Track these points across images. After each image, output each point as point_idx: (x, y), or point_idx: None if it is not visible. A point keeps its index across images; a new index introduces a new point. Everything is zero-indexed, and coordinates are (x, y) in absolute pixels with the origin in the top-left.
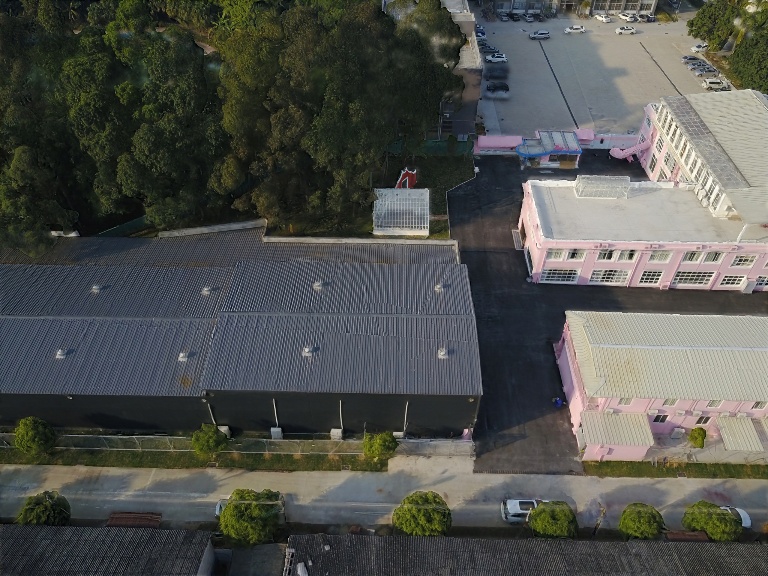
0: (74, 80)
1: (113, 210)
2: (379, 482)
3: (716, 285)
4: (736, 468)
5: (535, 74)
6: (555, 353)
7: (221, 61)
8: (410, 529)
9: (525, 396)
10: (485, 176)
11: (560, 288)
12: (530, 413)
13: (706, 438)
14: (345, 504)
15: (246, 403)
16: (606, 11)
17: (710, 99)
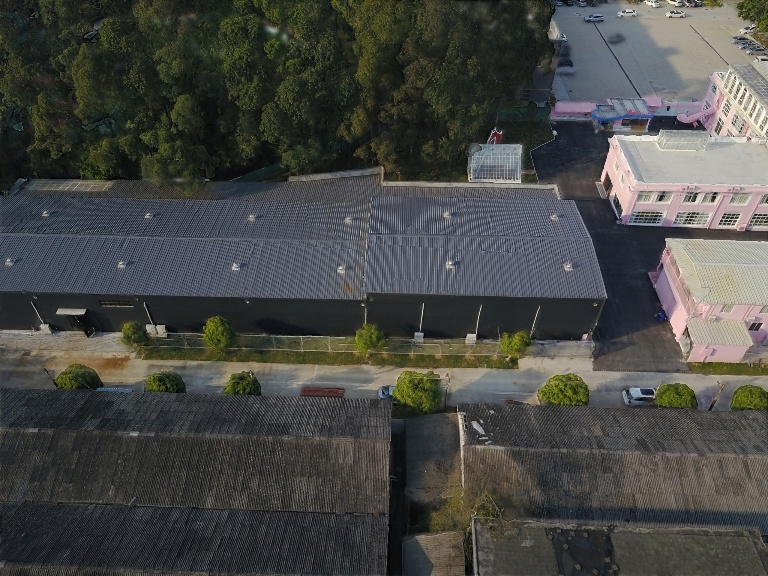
0: (230, 37)
1: (253, 155)
2: (513, 377)
3: None
4: None
5: (595, 52)
6: (651, 279)
7: (346, 25)
8: (558, 400)
9: (629, 313)
10: (563, 138)
11: (647, 229)
12: (636, 326)
13: None
14: (487, 392)
15: (398, 308)
16: None
17: None
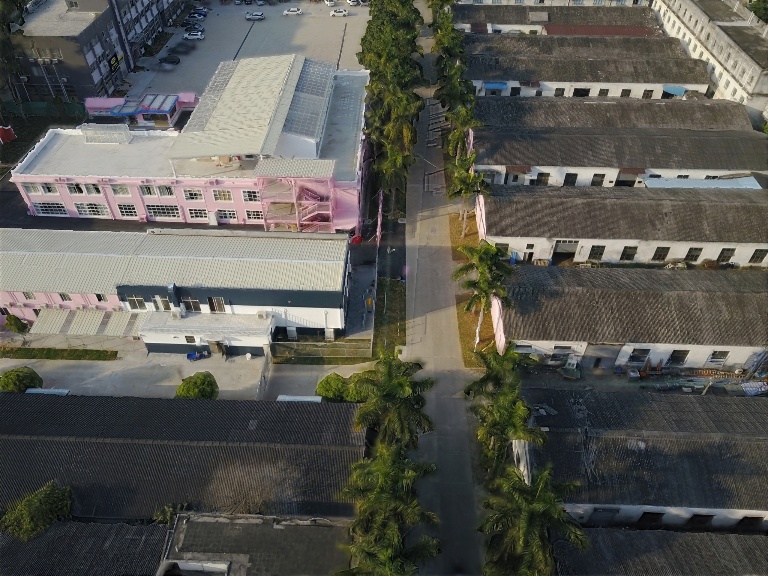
0: None
1: None
2: None
3: (188, 218)
4: (56, 352)
5: (221, 50)
6: None
7: None
8: None
9: None
10: None
11: (52, 220)
12: None
13: None
14: None
15: None
16: None
17: (256, 62)
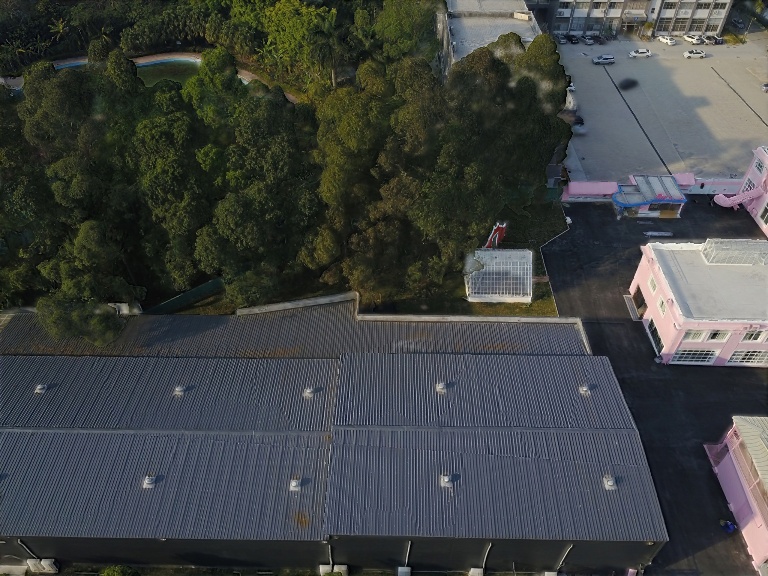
0: (150, 144)
1: (188, 287)
2: None
3: None
4: None
5: (607, 104)
6: (710, 458)
7: (308, 114)
8: None
9: (686, 517)
10: (579, 228)
11: (695, 370)
12: (697, 540)
13: None
14: None
15: (375, 544)
16: (669, 32)
17: None
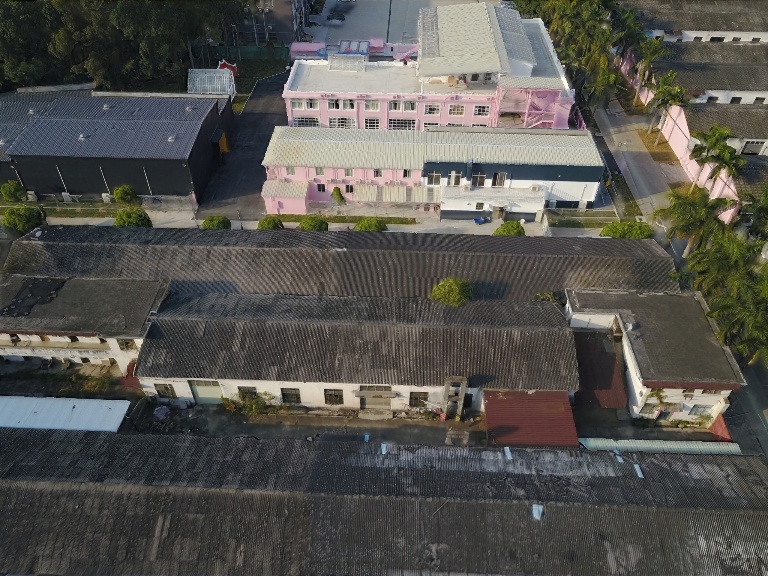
0: None
1: None
2: None
3: None
4: None
5: (374, 10)
6: None
7: None
8: (117, 223)
9: (247, 184)
10: None
11: None
12: (245, 192)
13: (356, 204)
14: None
15: (40, 170)
16: None
17: (453, 8)
